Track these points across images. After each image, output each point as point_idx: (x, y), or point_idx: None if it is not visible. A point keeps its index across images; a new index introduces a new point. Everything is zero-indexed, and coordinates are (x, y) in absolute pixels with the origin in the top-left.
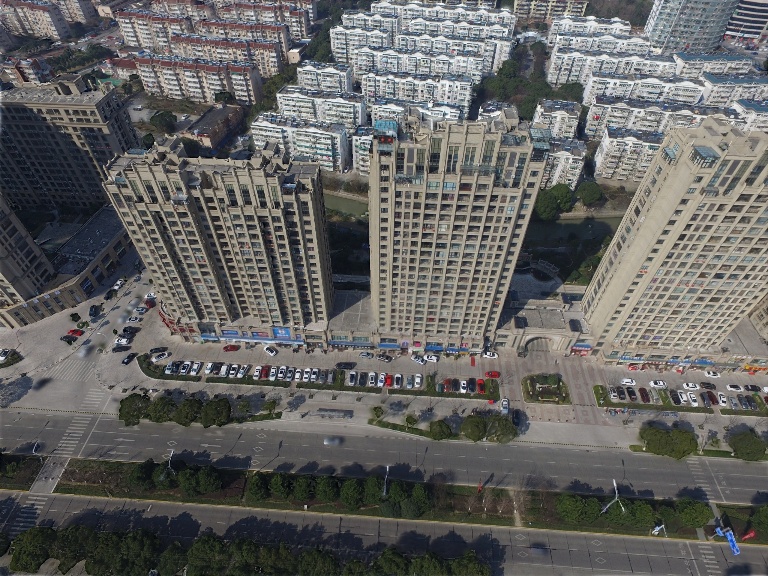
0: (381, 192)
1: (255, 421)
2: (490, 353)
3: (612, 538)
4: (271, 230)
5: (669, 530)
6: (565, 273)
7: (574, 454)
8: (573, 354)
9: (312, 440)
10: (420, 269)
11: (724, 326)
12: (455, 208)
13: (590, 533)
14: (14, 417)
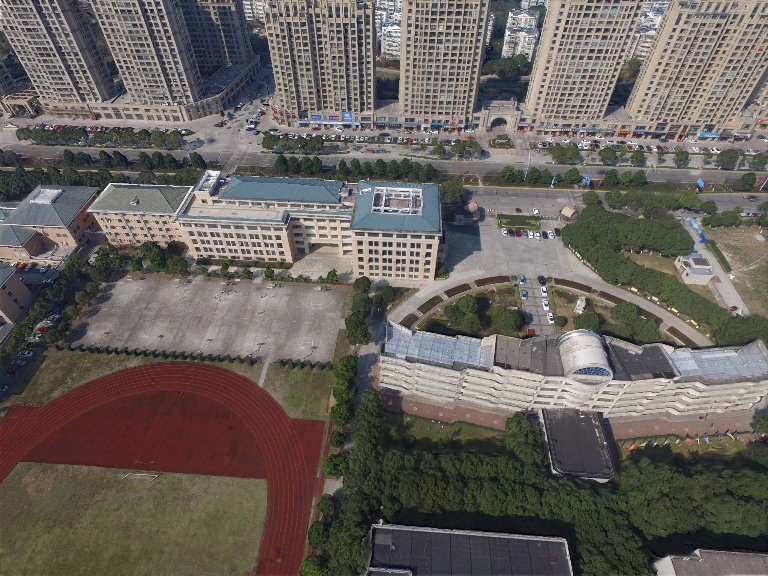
0: (409, 5)
1: (335, 154)
2: (470, 129)
3: (529, 189)
4: (349, 34)
5: (560, 186)
6: (519, 100)
7: (514, 165)
8: (519, 131)
9: (368, 160)
10: (429, 60)
11: (601, 100)
12: (447, 13)
13: (518, 188)
14: (200, 153)
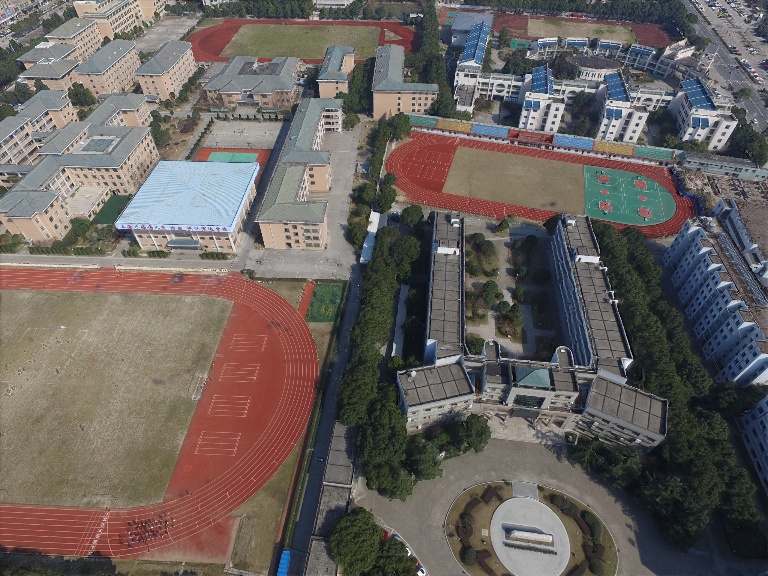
0: None
1: None
2: None
3: None
4: None
5: None
6: None
7: None
8: None
9: None
10: None
11: None
12: None
13: None
14: None
